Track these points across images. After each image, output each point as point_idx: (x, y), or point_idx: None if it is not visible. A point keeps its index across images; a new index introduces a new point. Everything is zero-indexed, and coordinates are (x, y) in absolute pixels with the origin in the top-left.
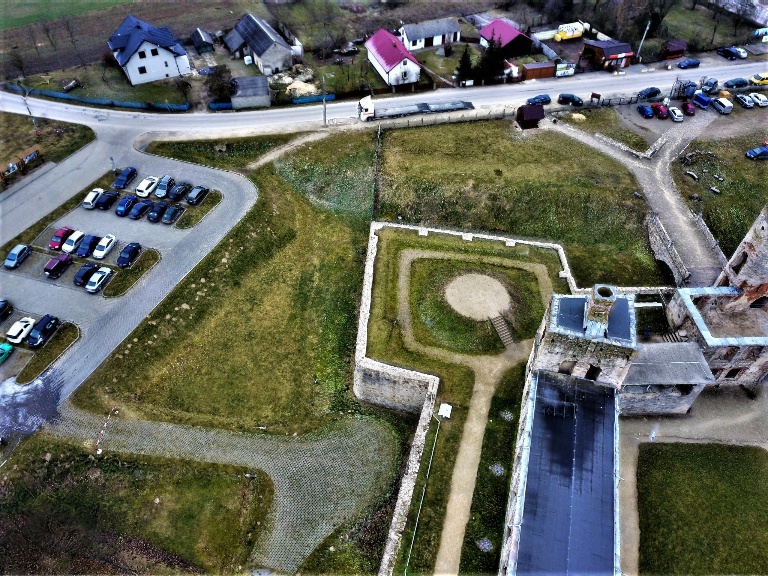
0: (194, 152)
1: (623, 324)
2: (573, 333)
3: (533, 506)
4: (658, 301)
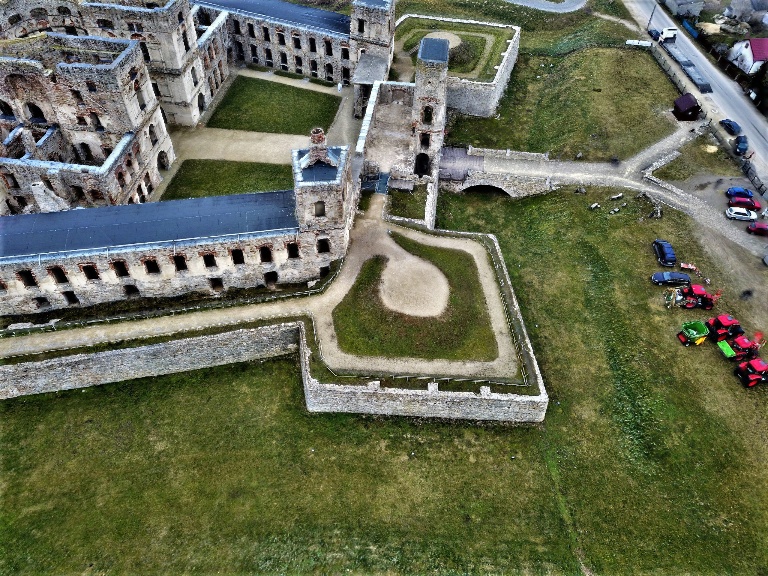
0: None
1: (367, 1)
2: None
3: None
4: None
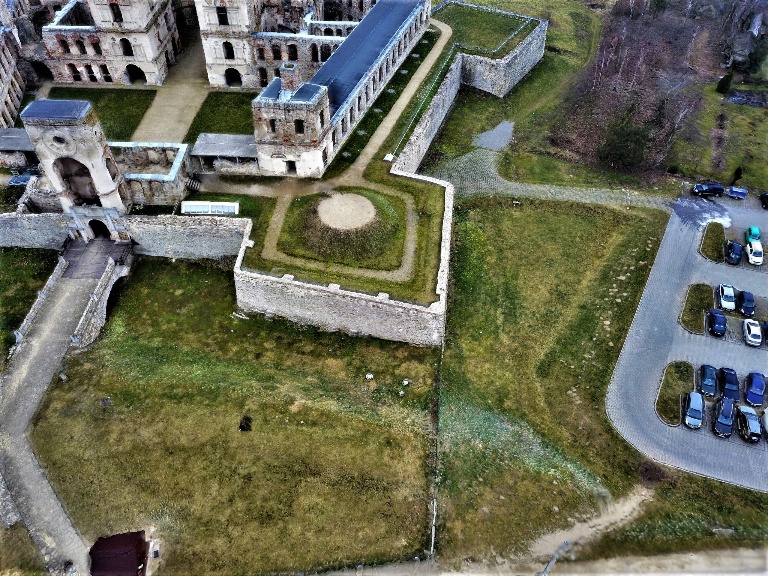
0: (763, 523)
1: (275, 85)
2: (312, 84)
3: (358, 76)
4: (178, 213)
